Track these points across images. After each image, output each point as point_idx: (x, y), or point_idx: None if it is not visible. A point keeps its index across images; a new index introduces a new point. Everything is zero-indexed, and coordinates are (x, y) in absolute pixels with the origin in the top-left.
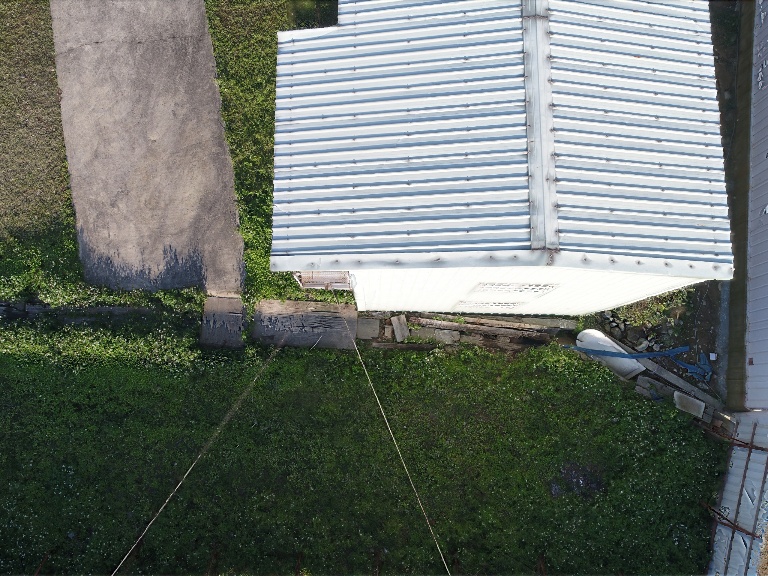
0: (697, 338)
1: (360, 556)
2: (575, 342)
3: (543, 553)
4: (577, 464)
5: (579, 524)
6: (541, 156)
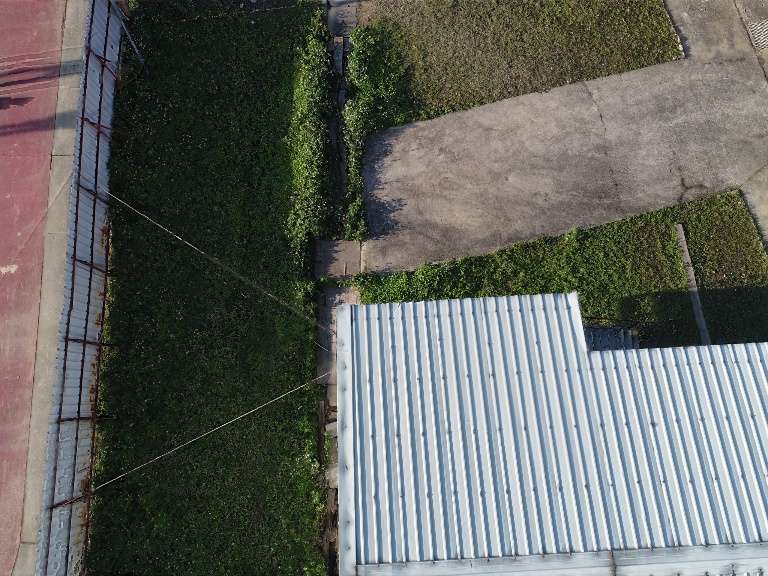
0: None
1: (127, 401)
2: None
3: None
4: None
5: None
6: (455, 574)
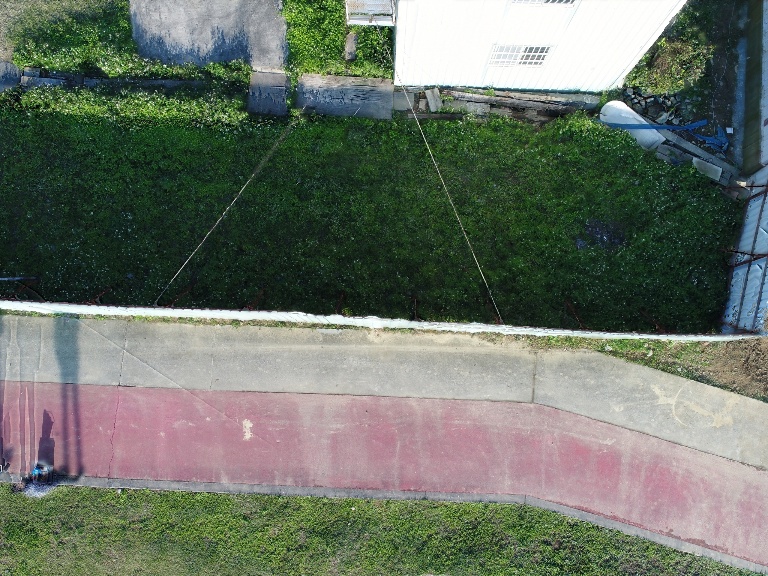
0: (714, 114)
1: (398, 295)
2: (599, 116)
3: (569, 296)
4: (601, 222)
5: (603, 269)
6: None
